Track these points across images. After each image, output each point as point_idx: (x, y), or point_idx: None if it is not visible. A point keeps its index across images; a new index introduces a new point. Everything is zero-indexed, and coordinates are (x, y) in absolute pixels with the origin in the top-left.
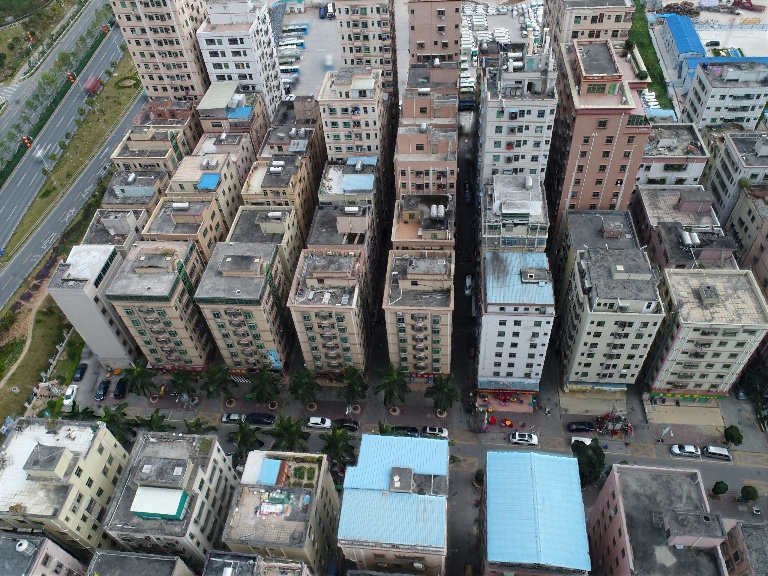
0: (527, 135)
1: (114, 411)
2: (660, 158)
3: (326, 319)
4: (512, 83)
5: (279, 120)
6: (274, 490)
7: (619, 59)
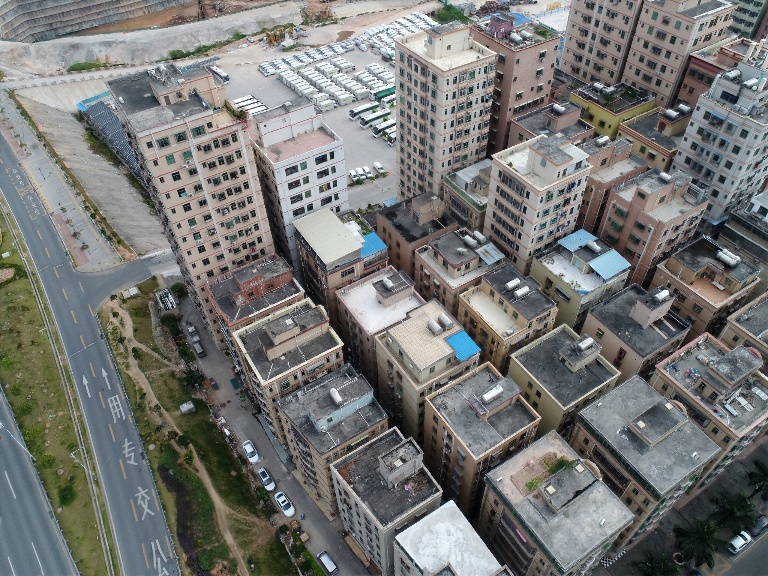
0: None
1: None
2: None
3: (759, 426)
4: (757, 102)
5: (401, 235)
6: None
7: None
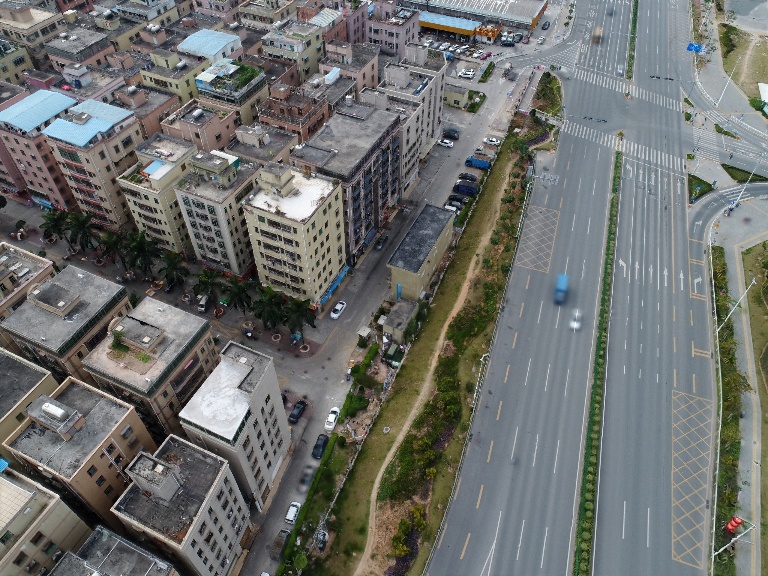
0: None
1: (262, 301)
2: None
3: None
4: None
5: None
6: None
7: None
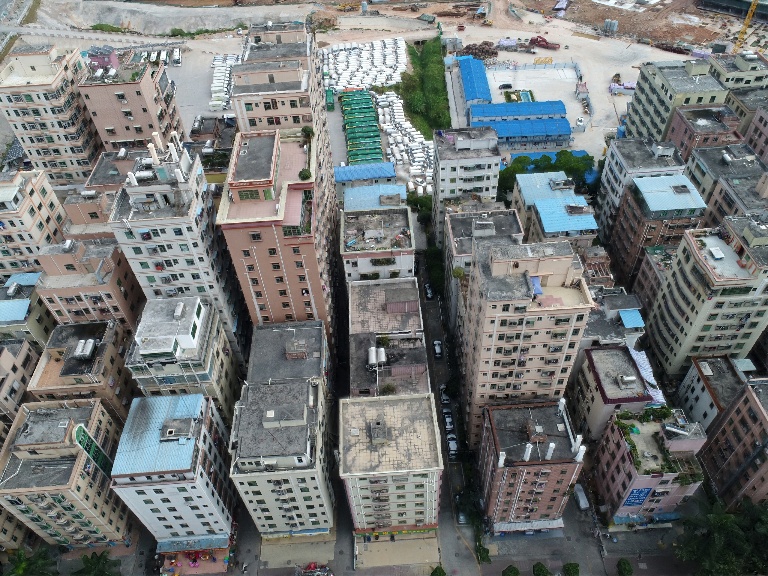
0: (174, 254)
1: None
2: (363, 253)
3: None
4: (143, 197)
5: None
6: None
7: (297, 150)
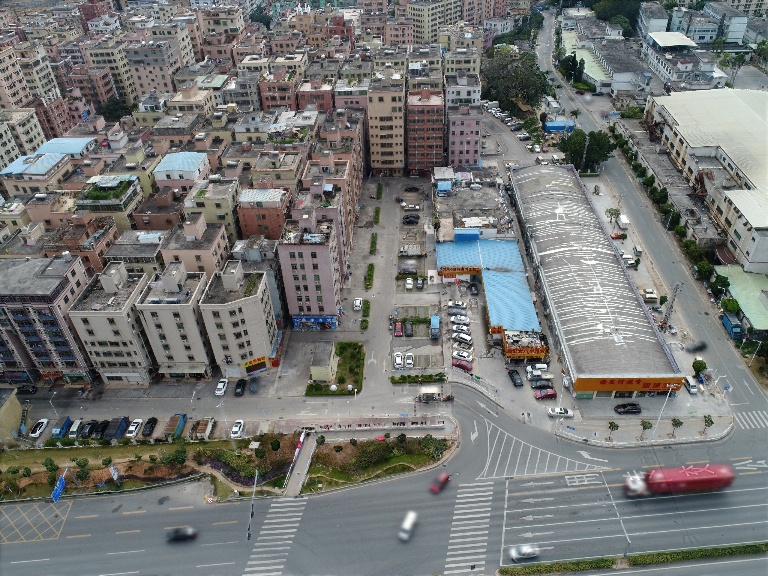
0: None
1: None
2: None
3: None
4: None
5: None
6: (4, 206)
7: None
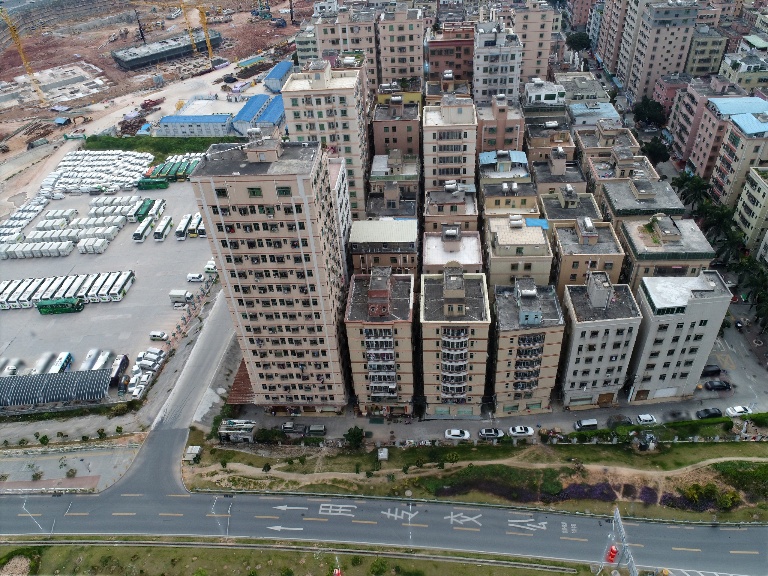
0: None
1: None
2: None
3: None
4: None
5: None
6: None
7: None
